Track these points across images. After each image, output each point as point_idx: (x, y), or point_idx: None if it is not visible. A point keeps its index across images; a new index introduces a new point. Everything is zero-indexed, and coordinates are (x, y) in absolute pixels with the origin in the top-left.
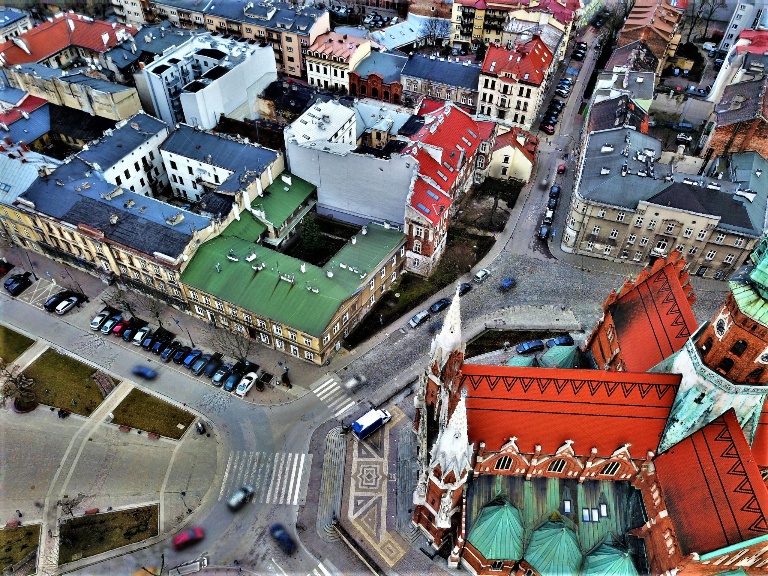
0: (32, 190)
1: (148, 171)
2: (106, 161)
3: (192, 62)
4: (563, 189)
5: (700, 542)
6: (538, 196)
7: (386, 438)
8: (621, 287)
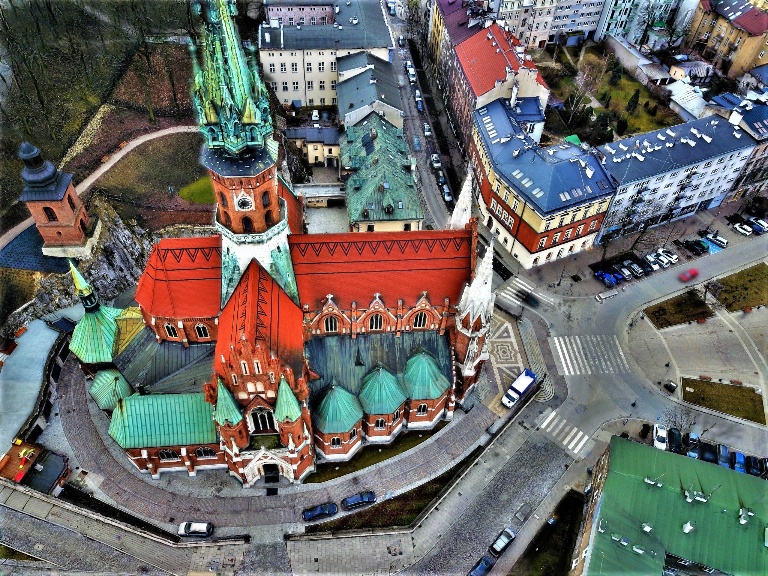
0: None
1: None
2: None
3: None
4: None
5: None
6: None
7: (500, 384)
8: (290, 389)
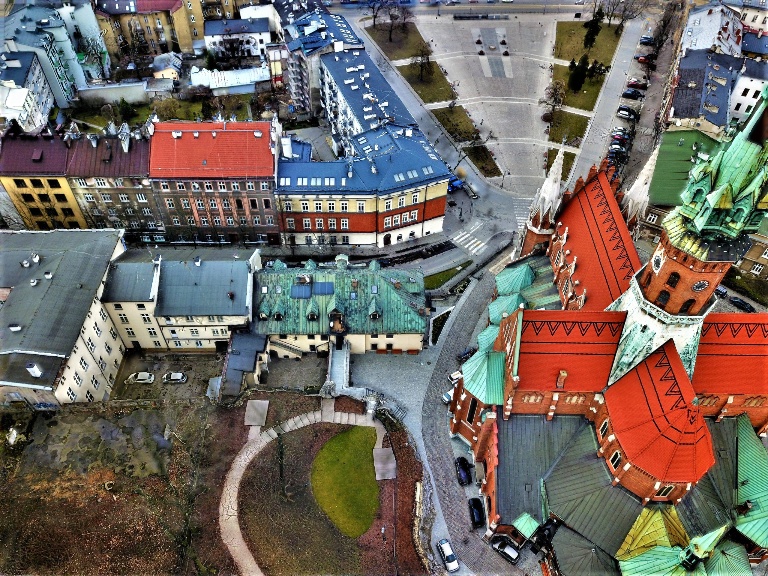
0: (697, 52)
1: None
2: (754, 73)
3: None
4: None
5: None
6: None
7: None
8: None
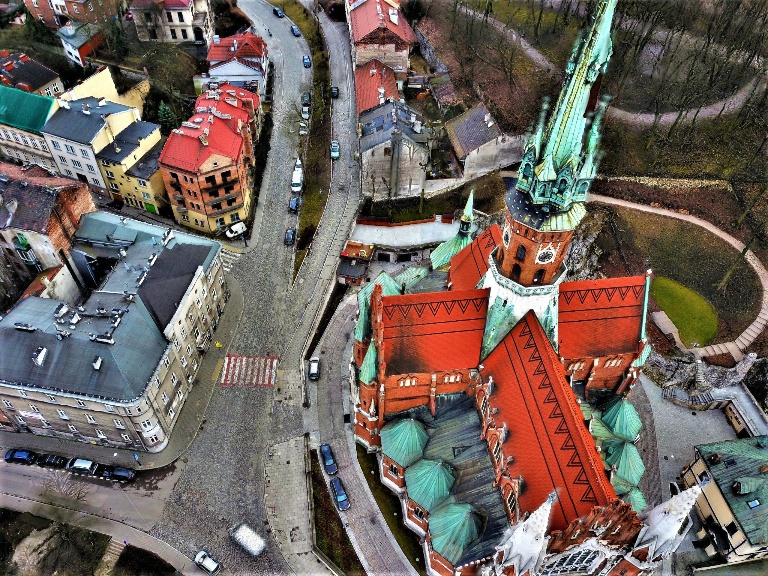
0: None
1: None
2: None
3: None
4: (14, 446)
5: (632, 336)
6: (24, 482)
7: None
8: (373, 356)
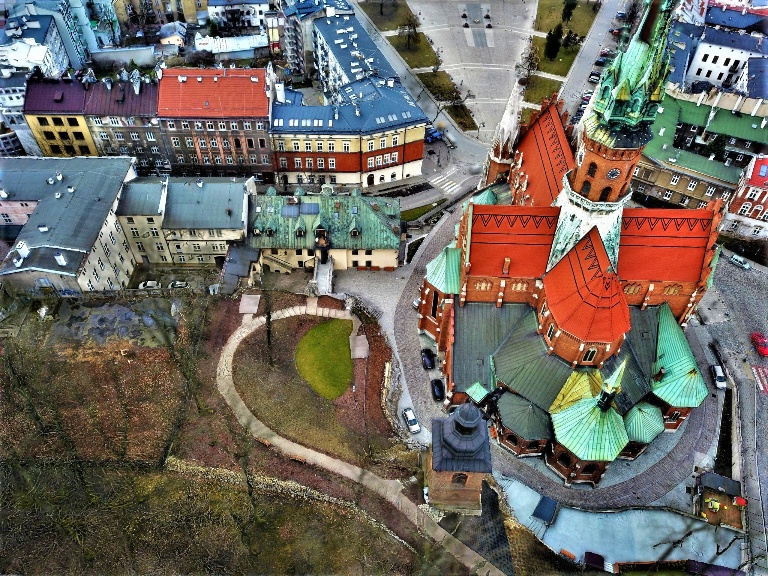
0: None
1: (732, 73)
2: (712, 40)
3: None
4: None
5: None
6: None
7: None
8: None
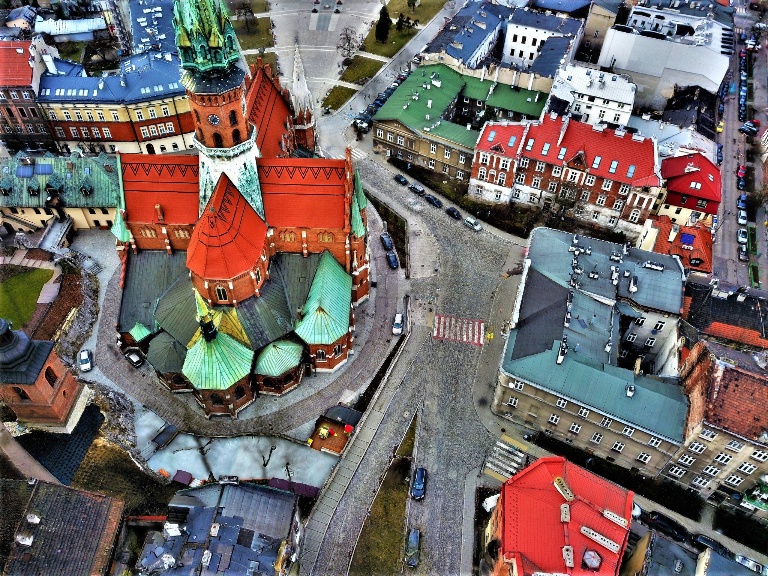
0: (477, 3)
1: None
2: (519, 20)
3: (671, 29)
4: None
5: None
6: None
7: None
8: None
